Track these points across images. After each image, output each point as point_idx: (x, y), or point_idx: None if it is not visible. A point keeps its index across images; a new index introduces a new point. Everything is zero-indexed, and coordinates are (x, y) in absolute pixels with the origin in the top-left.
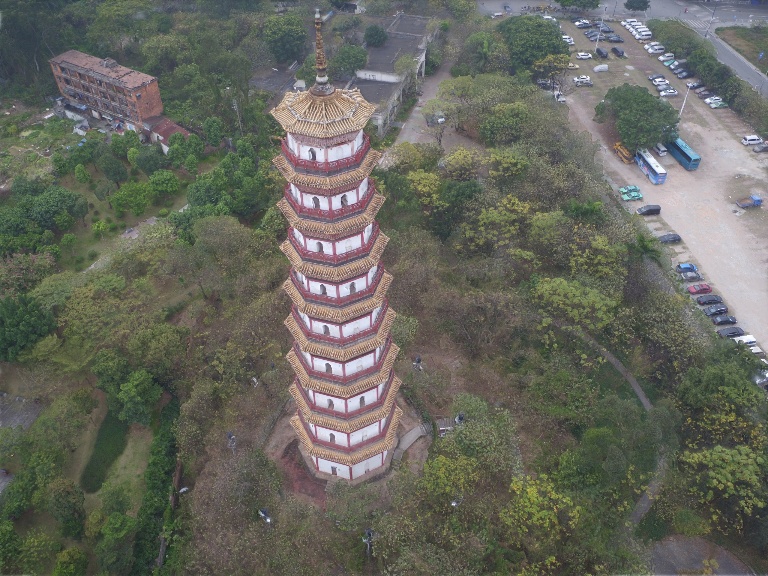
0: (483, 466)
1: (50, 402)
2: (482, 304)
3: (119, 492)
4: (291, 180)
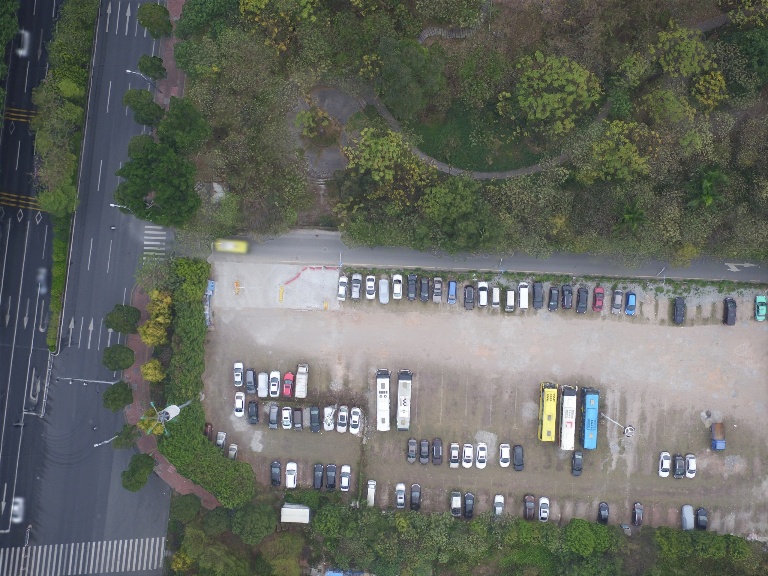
0: None
1: None
2: (580, 13)
3: None
4: None
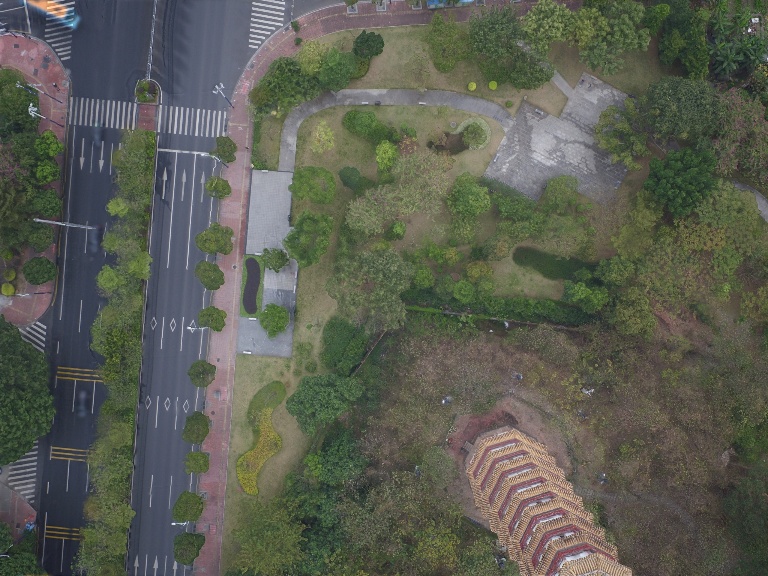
0: (458, 568)
1: (587, 225)
2: None
3: (490, 291)
4: (551, 544)
